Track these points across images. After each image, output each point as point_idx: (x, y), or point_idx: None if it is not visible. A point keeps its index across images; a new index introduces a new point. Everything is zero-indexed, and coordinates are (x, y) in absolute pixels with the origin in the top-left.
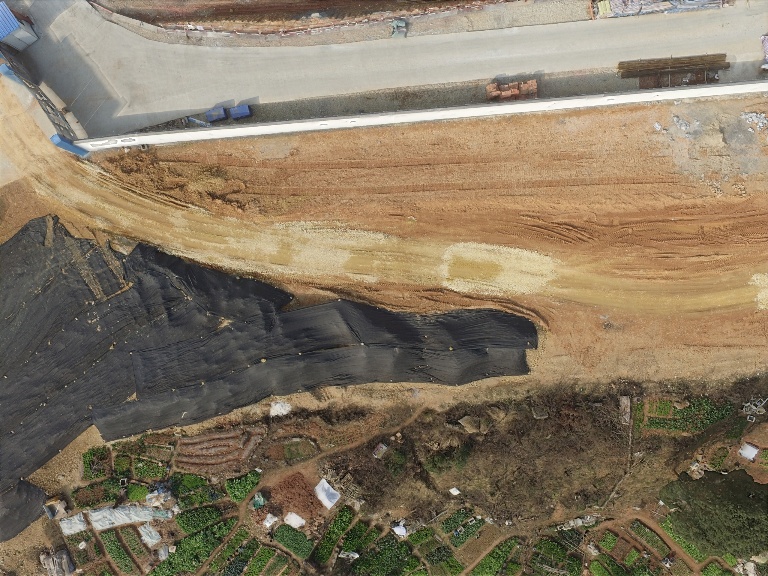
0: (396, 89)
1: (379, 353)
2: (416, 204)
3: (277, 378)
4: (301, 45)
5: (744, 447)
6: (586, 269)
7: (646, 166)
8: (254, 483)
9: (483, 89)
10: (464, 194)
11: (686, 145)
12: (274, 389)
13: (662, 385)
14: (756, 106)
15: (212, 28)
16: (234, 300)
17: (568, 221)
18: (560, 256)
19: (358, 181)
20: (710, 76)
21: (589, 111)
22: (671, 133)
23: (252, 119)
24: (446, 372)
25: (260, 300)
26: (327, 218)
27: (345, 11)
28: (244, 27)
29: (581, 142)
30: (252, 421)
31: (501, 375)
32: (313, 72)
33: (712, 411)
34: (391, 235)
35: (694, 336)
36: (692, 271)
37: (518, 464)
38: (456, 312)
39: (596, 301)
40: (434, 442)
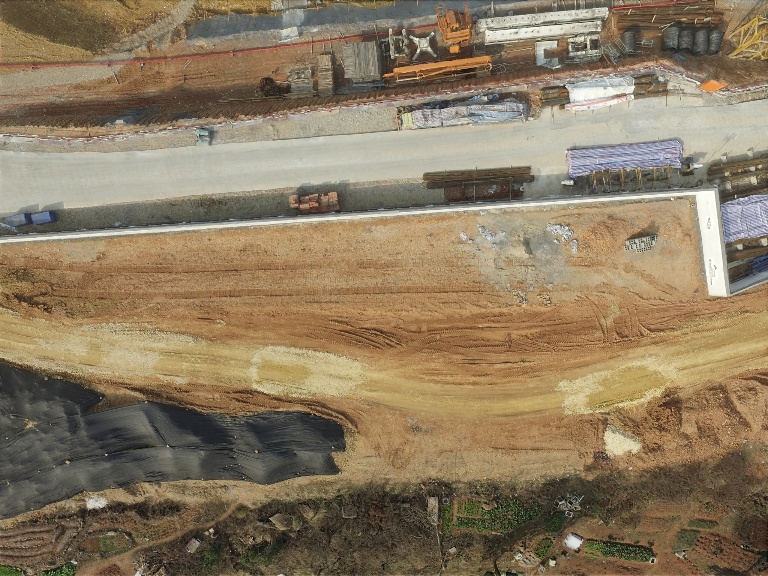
0: (201, 196)
1: (185, 455)
2: (224, 308)
3: (85, 477)
4: (106, 151)
5: (569, 537)
6: (394, 374)
7: (452, 275)
8: (69, 575)
9: (288, 197)
10: (270, 300)
11: (492, 255)
12: (85, 486)
13: (471, 486)
14: (561, 218)
15: (12, 135)
16: (38, 402)
17: (377, 326)
18: (368, 361)
19: (165, 286)
20: (515, 188)
21: (396, 220)
22: (477, 243)
23: (57, 223)
24: (255, 472)
25: (65, 402)
26: (136, 320)
27: (164, 109)
28: (48, 132)
29: (387, 250)
30: (68, 514)
31: (312, 474)
32: (117, 178)
33: (520, 512)
34: (200, 338)
35: (502, 440)
36: (499, 377)
37: (337, 556)
38: (265, 414)
39: (405, 405)
40: (250, 536)
